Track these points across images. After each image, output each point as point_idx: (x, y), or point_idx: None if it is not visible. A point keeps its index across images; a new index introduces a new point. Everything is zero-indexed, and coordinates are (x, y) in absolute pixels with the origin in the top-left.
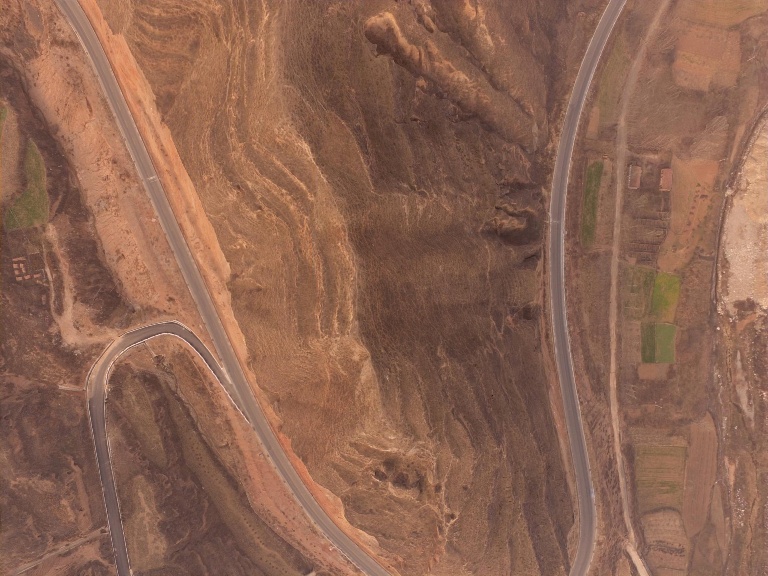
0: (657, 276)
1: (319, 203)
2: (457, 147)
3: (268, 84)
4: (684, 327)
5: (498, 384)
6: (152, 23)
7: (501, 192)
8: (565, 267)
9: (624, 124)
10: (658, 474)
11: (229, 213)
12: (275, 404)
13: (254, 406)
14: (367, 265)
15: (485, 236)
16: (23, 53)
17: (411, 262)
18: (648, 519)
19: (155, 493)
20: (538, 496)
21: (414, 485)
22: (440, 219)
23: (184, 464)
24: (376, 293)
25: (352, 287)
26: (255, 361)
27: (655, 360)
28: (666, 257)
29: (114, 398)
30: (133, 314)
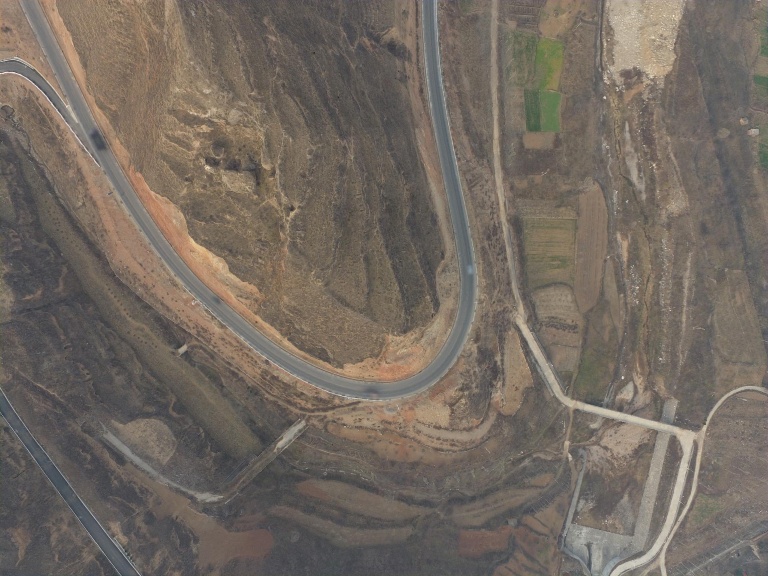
0: (539, 41)
1: None
2: None
3: None
4: (569, 94)
5: (344, 85)
6: None
7: None
8: (439, 21)
9: None
10: (548, 248)
11: None
12: None
13: (104, 147)
14: None
15: None
16: None
17: None
18: (539, 294)
19: None
20: (398, 218)
21: (246, 168)
22: None
23: (40, 229)
24: None
25: None
26: (87, 68)
27: (540, 129)
28: (548, 22)
29: None
30: None
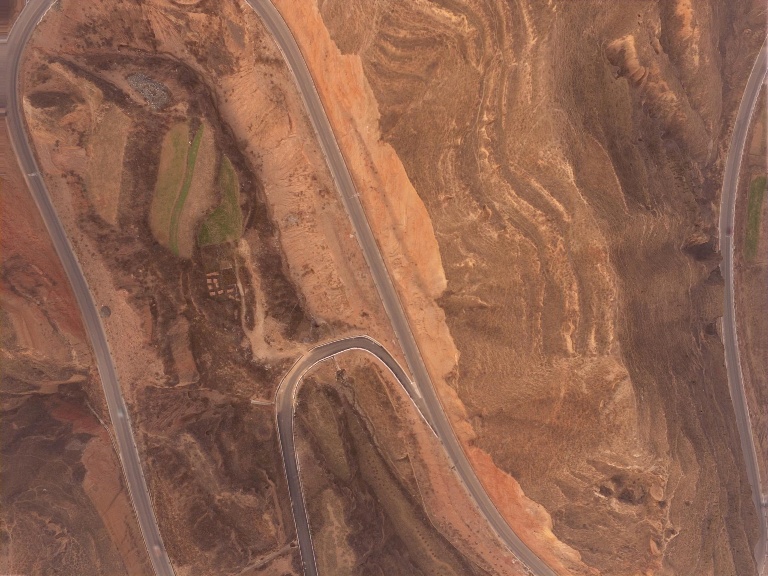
0: None
1: (577, 224)
2: None
3: (535, 107)
4: None
5: (707, 400)
6: (396, 44)
7: (699, 209)
8: (734, 281)
9: None
10: None
11: (464, 232)
12: (476, 419)
13: (443, 420)
14: (625, 286)
15: (685, 253)
16: (216, 69)
17: (647, 281)
18: None
19: (344, 507)
20: (735, 510)
21: (641, 501)
22: (660, 238)
23: (361, 477)
24: (630, 313)
25: (612, 308)
26: (465, 377)
27: None
28: None
29: (301, 412)
30: (319, 328)
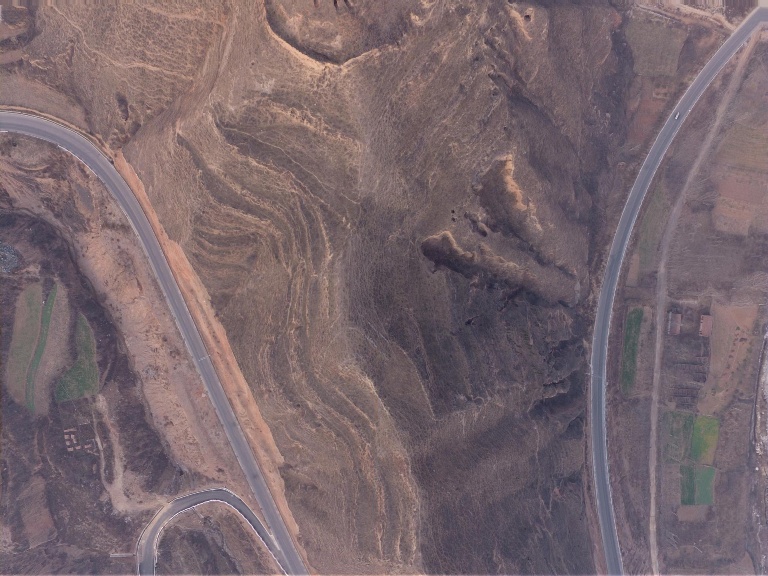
0: (696, 419)
1: (381, 433)
2: (508, 337)
3: (332, 323)
4: (723, 469)
5: (549, 570)
6: (211, 241)
7: (549, 369)
8: (606, 418)
9: (664, 270)
10: None
11: (287, 422)
12: None
13: (302, 571)
14: (429, 495)
15: (533, 415)
16: (72, 226)
17: (468, 472)
18: None
19: None
20: None
21: None
22: (493, 416)
23: None
24: (437, 519)
25: (415, 518)
26: (308, 546)
27: (694, 502)
28: (705, 400)
29: (163, 561)
30: (181, 478)
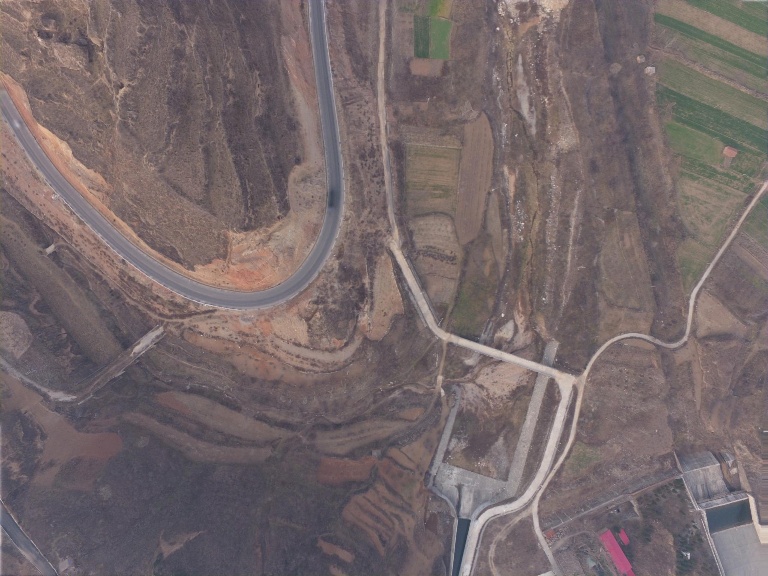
0: None
1: None
2: None
3: None
4: (460, 22)
5: None
6: None
7: None
8: None
9: None
10: (430, 176)
11: None
12: None
13: None
14: None
15: None
16: None
17: None
18: (418, 223)
19: None
20: (246, 115)
21: (74, 41)
22: None
23: None
24: None
25: None
26: None
27: (429, 55)
28: None
29: None
30: None
